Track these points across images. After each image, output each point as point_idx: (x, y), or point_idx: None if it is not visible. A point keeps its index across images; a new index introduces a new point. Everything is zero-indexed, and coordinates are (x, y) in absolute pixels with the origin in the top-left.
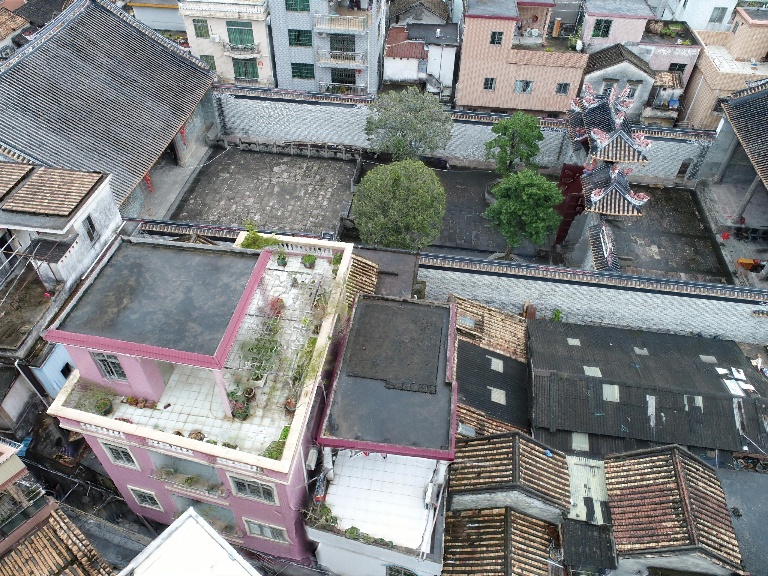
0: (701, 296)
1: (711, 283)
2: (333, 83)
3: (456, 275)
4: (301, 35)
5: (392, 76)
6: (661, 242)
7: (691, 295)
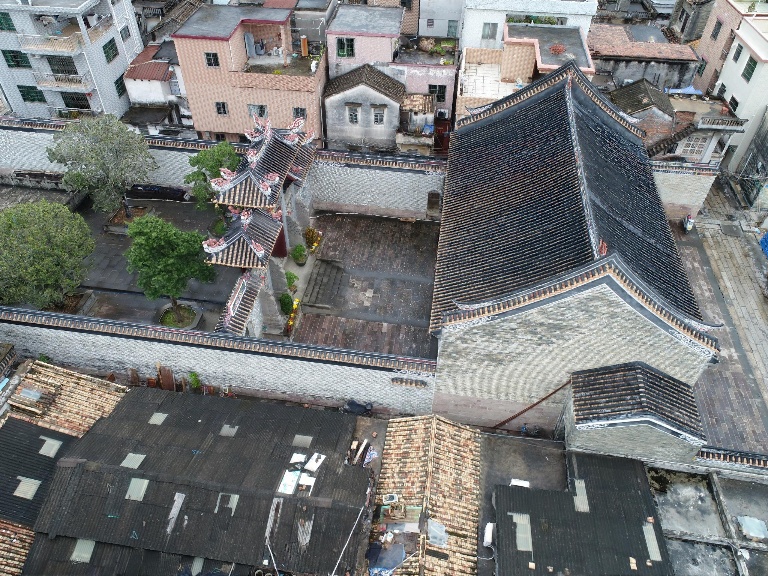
0: (329, 361)
1: (335, 348)
2: (61, 107)
3: (69, 334)
4: (17, 56)
5: (139, 98)
6: (380, 286)
7: (318, 360)
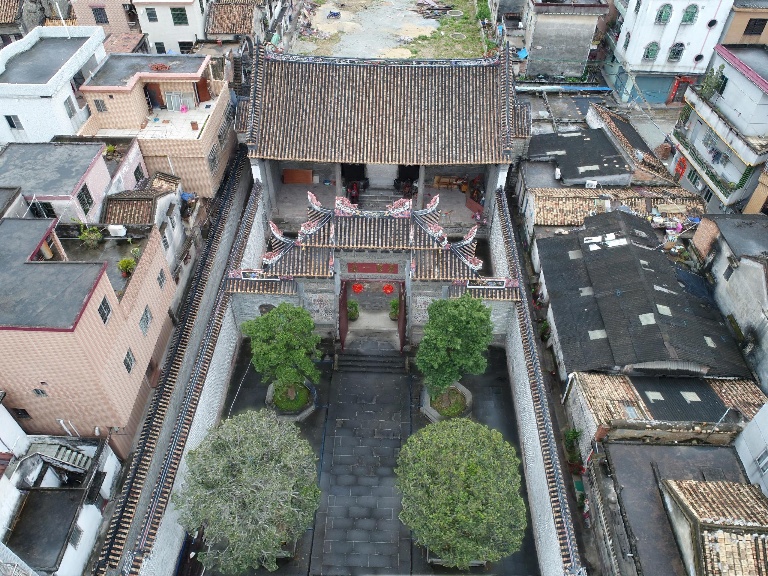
0: None
1: (510, 229)
2: None
3: None
4: None
5: None
6: None
7: None
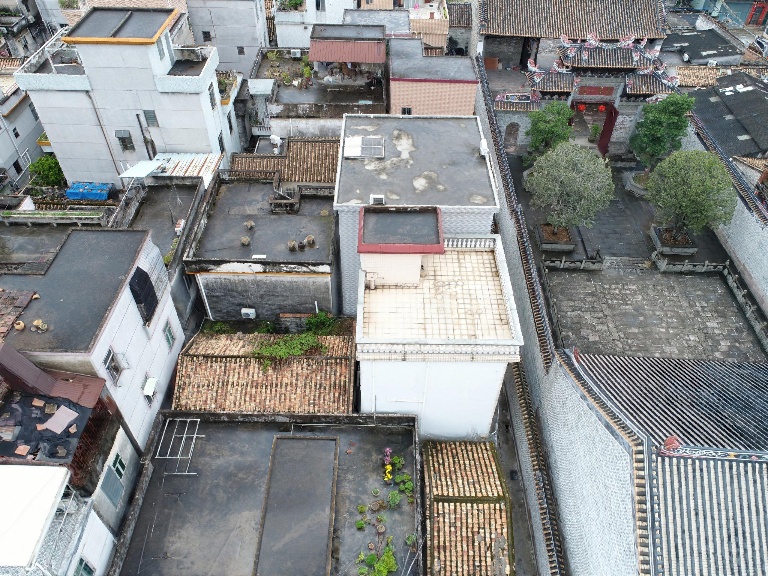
0: None
1: None
2: None
3: None
4: None
5: None
6: None
7: None
